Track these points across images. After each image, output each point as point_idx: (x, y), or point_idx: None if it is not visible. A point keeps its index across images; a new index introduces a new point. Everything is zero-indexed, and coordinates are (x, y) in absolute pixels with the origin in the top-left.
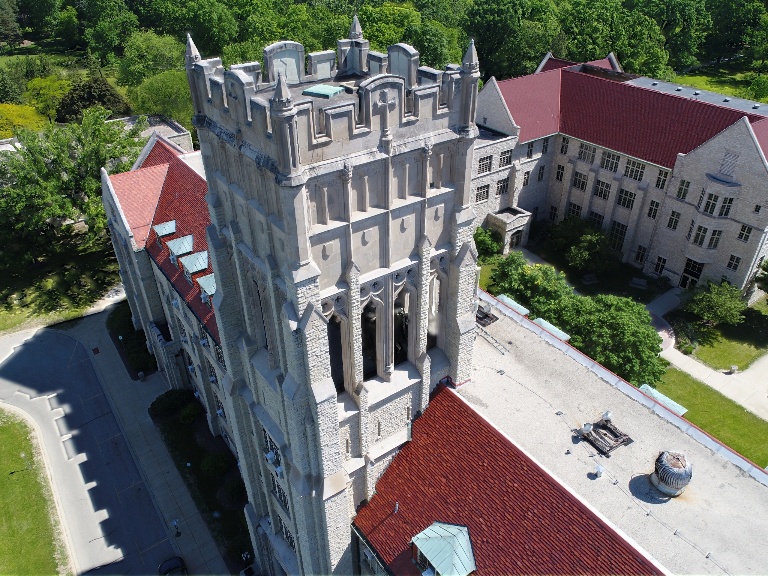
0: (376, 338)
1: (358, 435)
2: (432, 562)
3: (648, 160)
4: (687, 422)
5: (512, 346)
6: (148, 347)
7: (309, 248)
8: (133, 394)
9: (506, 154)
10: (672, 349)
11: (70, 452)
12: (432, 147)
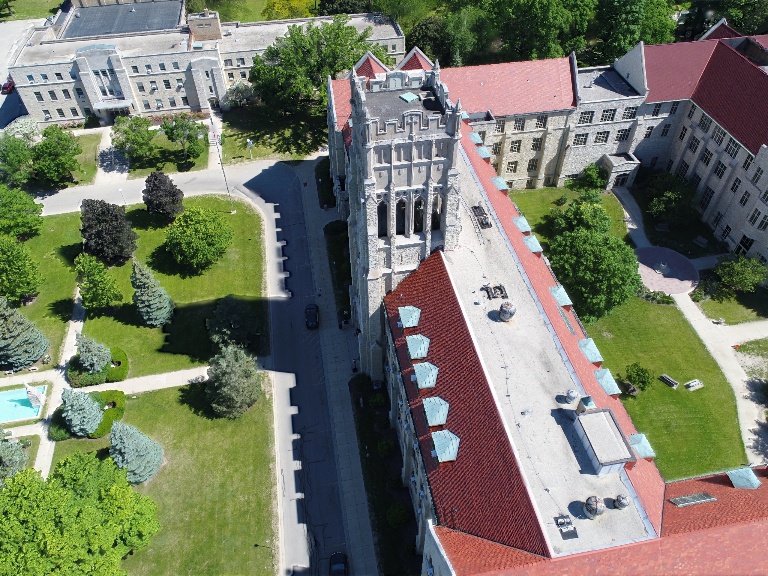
0: (405, 216)
1: (390, 258)
2: (401, 318)
3: (742, 143)
4: (539, 299)
5: (488, 242)
6: (334, 191)
7: (373, 172)
8: (318, 216)
9: (631, 109)
10: (686, 294)
11: (279, 238)
12: (436, 140)
